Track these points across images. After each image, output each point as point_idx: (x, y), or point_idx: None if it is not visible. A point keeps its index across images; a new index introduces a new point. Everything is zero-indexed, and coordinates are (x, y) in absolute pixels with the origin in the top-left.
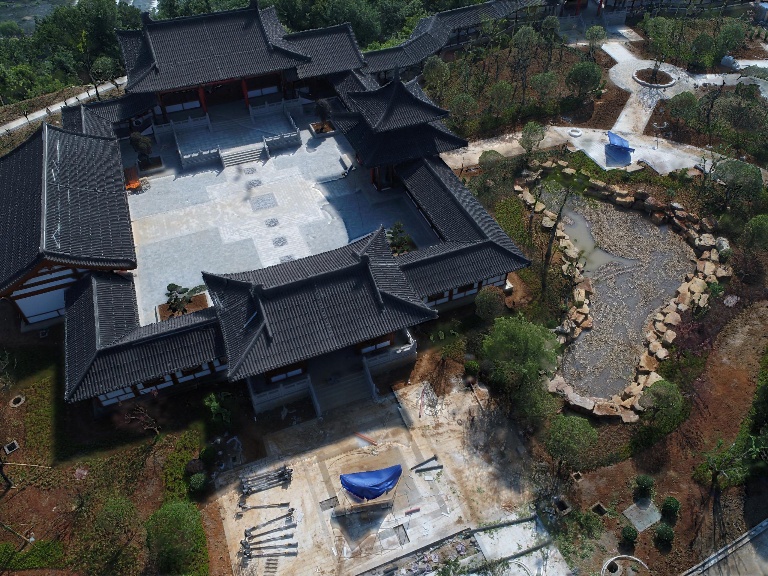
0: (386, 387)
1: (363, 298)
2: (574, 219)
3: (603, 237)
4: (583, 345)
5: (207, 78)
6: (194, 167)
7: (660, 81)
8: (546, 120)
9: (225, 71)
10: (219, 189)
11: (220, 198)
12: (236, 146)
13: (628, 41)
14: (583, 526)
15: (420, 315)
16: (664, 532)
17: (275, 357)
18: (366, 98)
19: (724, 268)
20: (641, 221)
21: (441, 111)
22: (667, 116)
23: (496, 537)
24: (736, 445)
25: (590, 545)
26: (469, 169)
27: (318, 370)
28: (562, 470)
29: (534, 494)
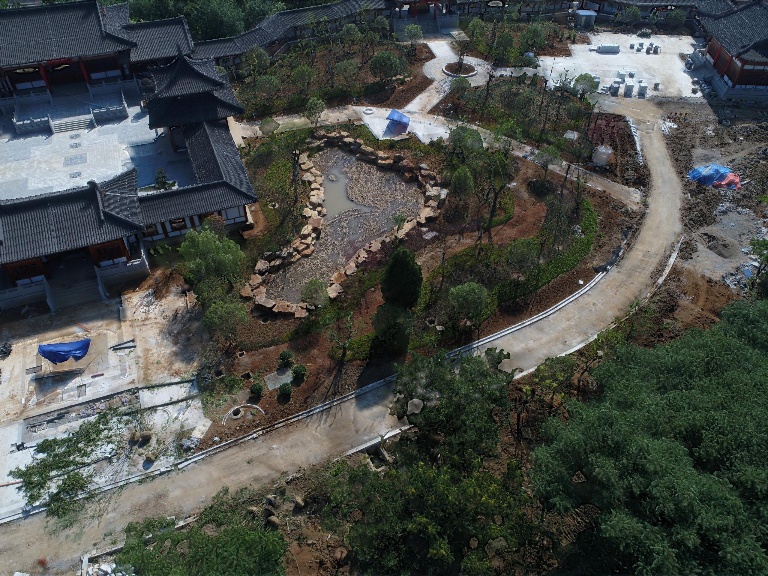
0: (117, 293)
1: (89, 216)
2: (338, 177)
3: (355, 190)
4: (297, 267)
5: (42, 57)
6: (28, 133)
7: (463, 72)
8: (349, 101)
9: (59, 52)
10: (42, 150)
11: (40, 156)
12: (68, 117)
13: (454, 40)
14: (227, 386)
15: (132, 229)
16: (282, 387)
17: (2, 256)
18: (161, 72)
19: (433, 211)
20: (394, 179)
21: (218, 83)
22: (453, 99)
23: (155, 393)
24: (374, 332)
25: (226, 398)
26: (263, 137)
27: (60, 278)
28: (230, 349)
29: (200, 365)
